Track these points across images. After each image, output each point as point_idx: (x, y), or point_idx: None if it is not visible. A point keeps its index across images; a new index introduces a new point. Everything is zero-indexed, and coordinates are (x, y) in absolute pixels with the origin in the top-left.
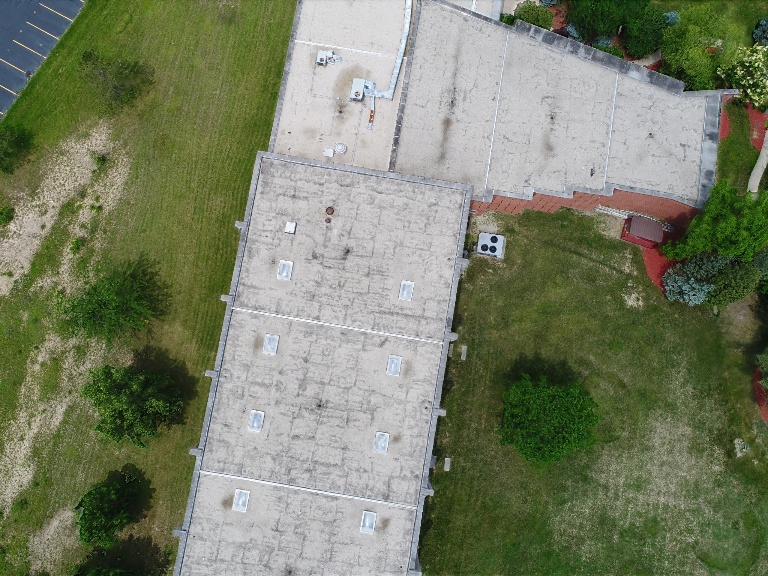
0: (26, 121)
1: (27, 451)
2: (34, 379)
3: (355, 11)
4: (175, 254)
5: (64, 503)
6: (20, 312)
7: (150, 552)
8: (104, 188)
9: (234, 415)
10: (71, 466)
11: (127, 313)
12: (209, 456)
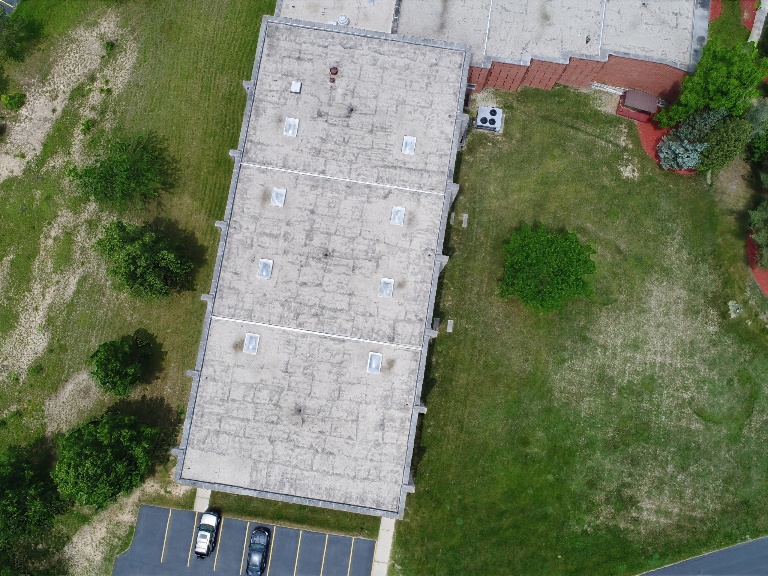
0: (36, 12)
1: (42, 320)
2: (47, 253)
3: None
4: (183, 130)
5: (78, 367)
6: (33, 191)
7: (163, 412)
8: (113, 72)
9: (244, 264)
10: (85, 333)
11: (138, 179)
12: (220, 302)
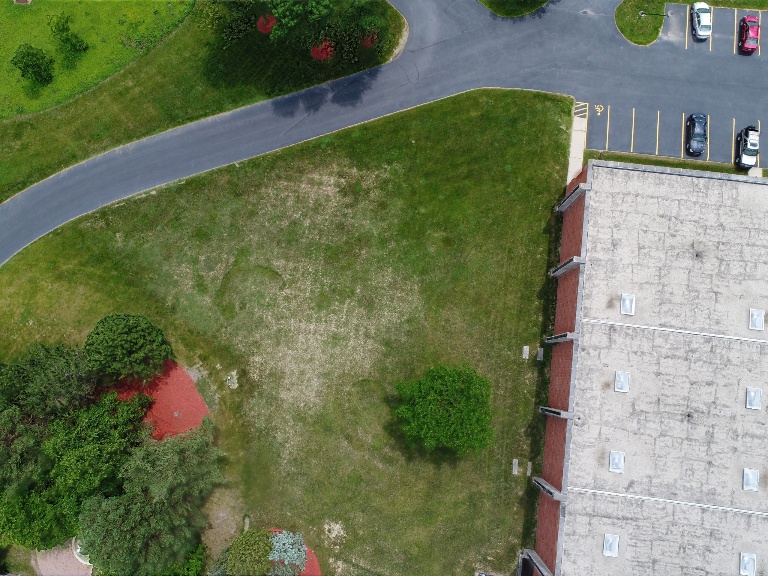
0: None
1: None
2: None
3: None
4: None
5: None
6: None
7: None
8: None
9: None
10: None
11: None
12: None
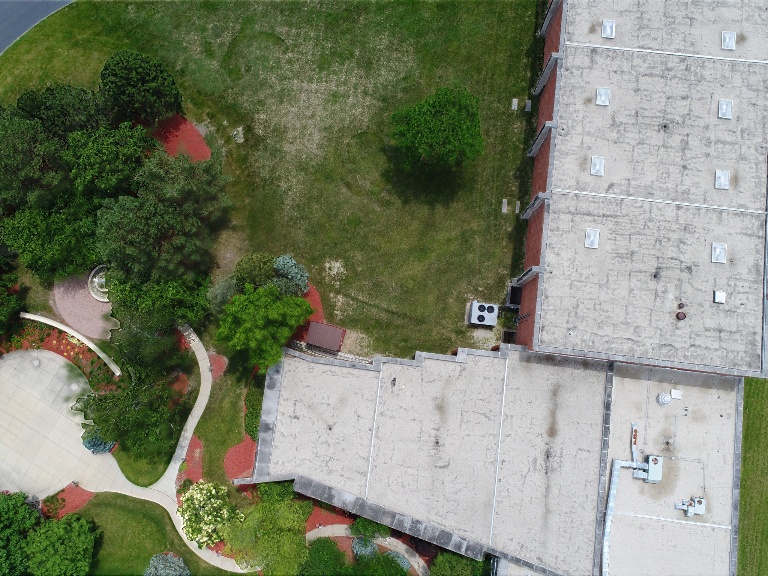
0: None
1: None
2: None
3: (666, 569)
4: None
5: None
6: None
7: None
8: None
9: (747, 114)
10: None
11: None
12: (765, 77)
